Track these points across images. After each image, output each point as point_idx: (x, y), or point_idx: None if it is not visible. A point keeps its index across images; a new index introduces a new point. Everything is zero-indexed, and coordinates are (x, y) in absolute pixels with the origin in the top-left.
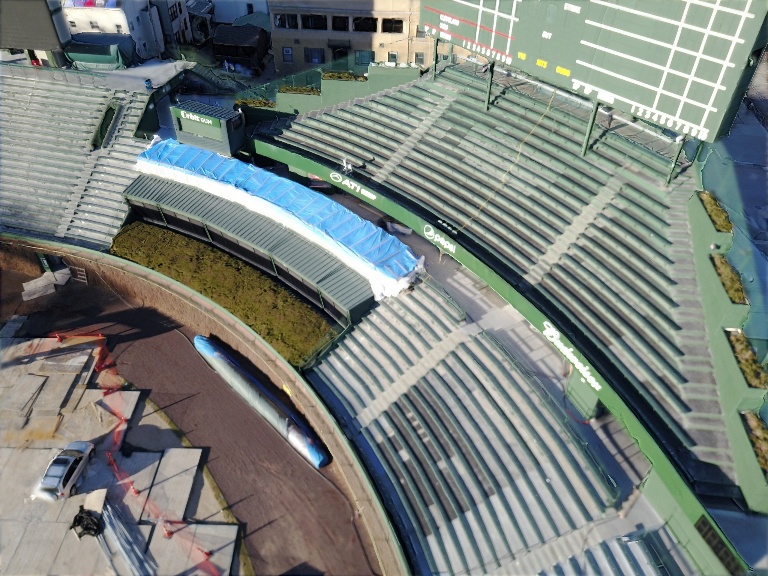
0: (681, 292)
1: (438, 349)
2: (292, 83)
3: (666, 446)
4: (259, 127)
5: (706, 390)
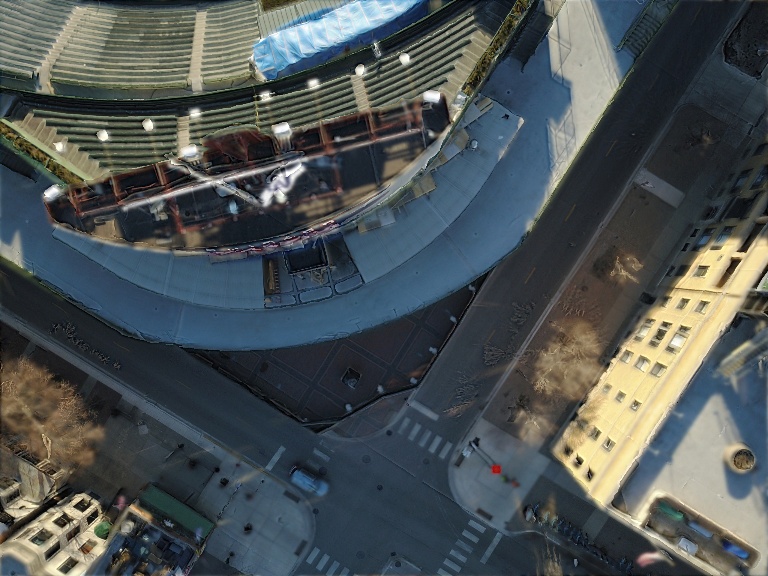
0: (95, 166)
1: (199, 61)
2: (759, 153)
3: (43, 105)
4: (502, 3)
5: (50, 141)
